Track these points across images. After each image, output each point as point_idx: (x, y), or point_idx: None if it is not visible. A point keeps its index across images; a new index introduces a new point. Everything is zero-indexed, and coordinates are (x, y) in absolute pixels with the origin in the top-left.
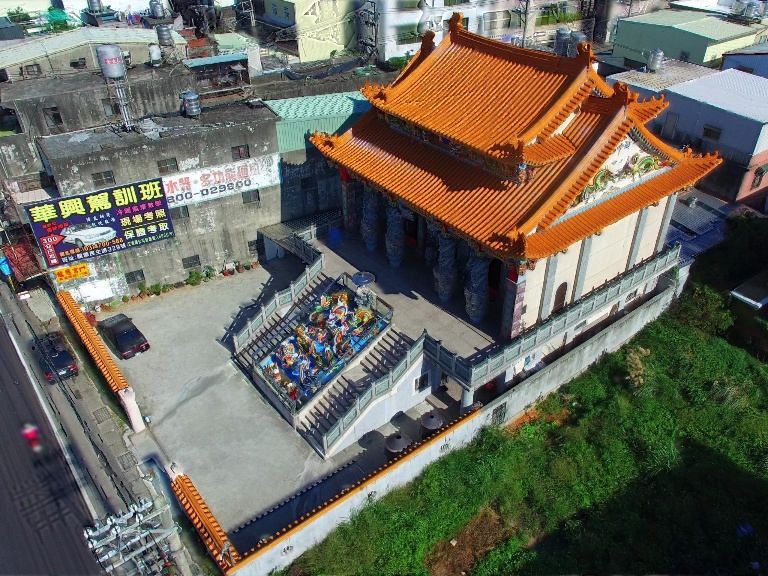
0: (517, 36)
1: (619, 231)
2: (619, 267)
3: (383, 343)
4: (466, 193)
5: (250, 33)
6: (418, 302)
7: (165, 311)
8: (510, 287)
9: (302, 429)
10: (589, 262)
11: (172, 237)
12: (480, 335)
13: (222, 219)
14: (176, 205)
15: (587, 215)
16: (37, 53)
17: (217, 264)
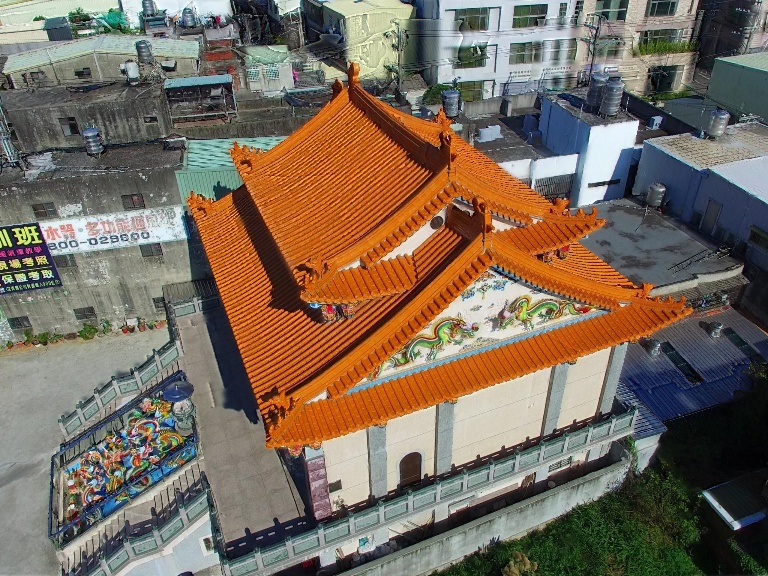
0: (584, 70)
1: (515, 389)
2: (527, 431)
3: (182, 480)
4: (283, 314)
5: (256, 51)
6: (254, 428)
7: (38, 367)
8: (303, 459)
9: (64, 569)
10: (460, 427)
11: (59, 286)
12: (294, 499)
13: (118, 271)
14: (60, 253)
15: (425, 378)
16: (43, 60)
17: (117, 318)
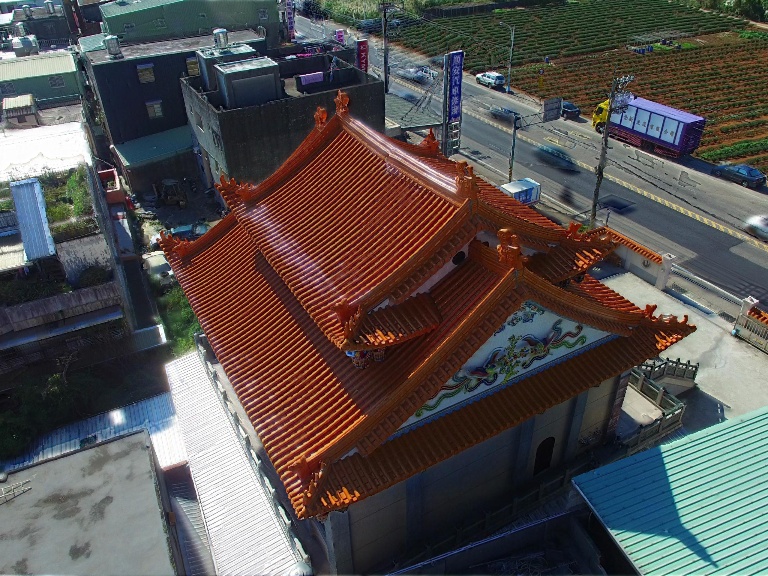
0: None
1: None
2: None
3: None
4: None
5: None
6: None
7: None
8: None
9: None
10: None
11: None
12: None
13: None
14: None
15: None
16: None
17: None
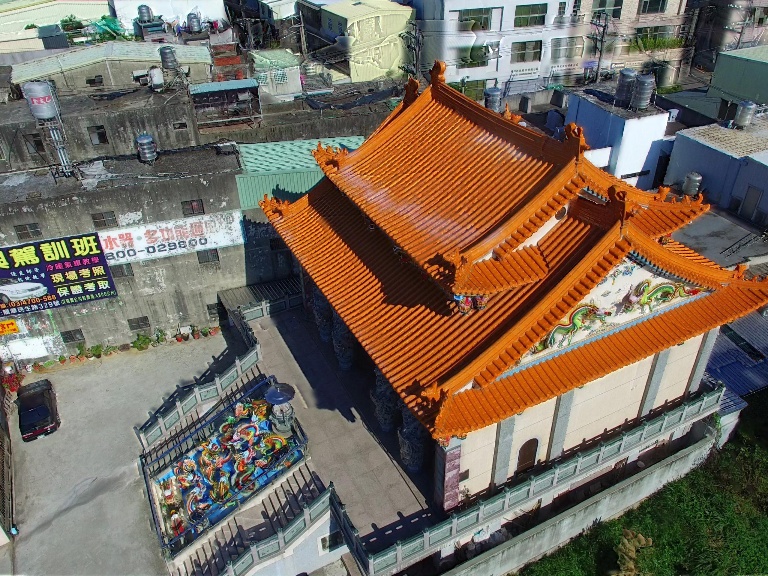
0: (591, 66)
1: (623, 373)
2: (627, 413)
3: (292, 481)
4: (402, 310)
5: (274, 55)
6: (353, 426)
7: (97, 380)
8: (439, 450)
9: None
10: (574, 412)
11: (114, 296)
12: (412, 492)
13: (174, 279)
14: (117, 262)
15: (558, 364)
16: (53, 69)
17: (170, 327)
